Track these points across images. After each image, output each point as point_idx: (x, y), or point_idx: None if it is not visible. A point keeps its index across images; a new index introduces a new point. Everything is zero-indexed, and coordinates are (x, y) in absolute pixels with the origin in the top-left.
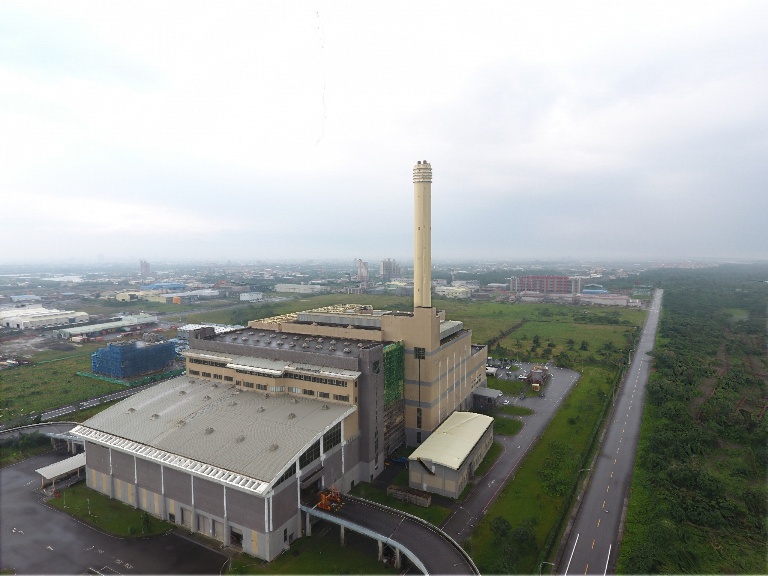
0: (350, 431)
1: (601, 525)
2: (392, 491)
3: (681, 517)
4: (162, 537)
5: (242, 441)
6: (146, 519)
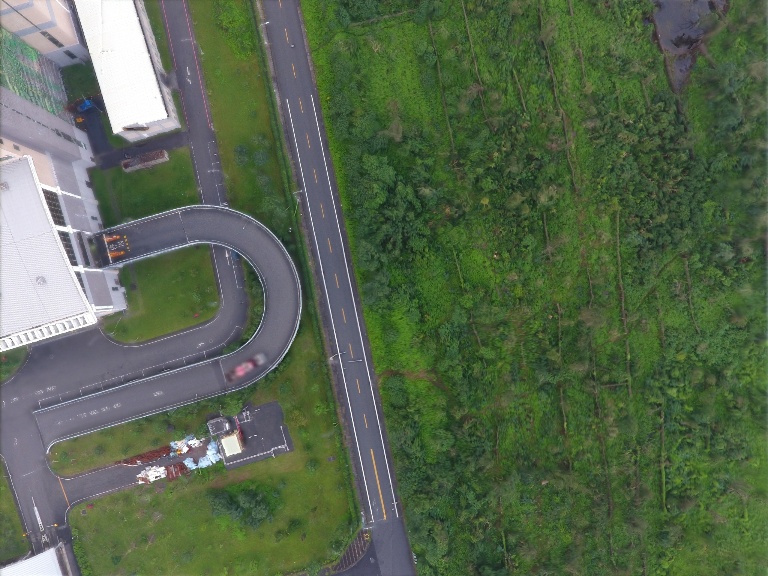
0: (47, 172)
1: (297, 73)
2: (129, 169)
3: (347, 24)
4: (32, 356)
5: (1, 295)
6: (6, 366)
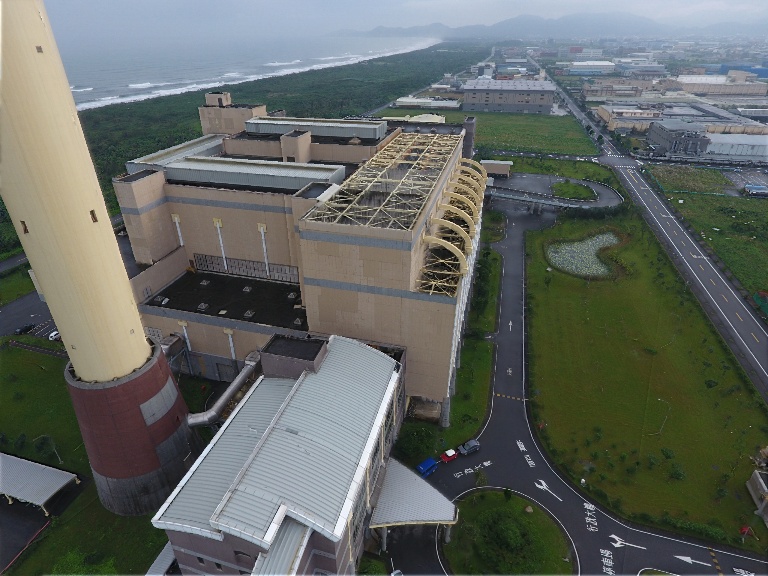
0: None
1: None
2: None
3: None
4: None
5: None
6: None
